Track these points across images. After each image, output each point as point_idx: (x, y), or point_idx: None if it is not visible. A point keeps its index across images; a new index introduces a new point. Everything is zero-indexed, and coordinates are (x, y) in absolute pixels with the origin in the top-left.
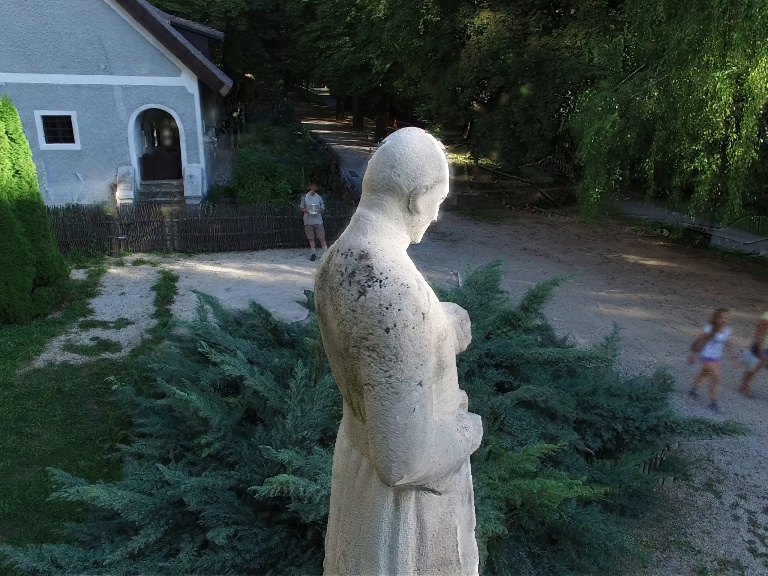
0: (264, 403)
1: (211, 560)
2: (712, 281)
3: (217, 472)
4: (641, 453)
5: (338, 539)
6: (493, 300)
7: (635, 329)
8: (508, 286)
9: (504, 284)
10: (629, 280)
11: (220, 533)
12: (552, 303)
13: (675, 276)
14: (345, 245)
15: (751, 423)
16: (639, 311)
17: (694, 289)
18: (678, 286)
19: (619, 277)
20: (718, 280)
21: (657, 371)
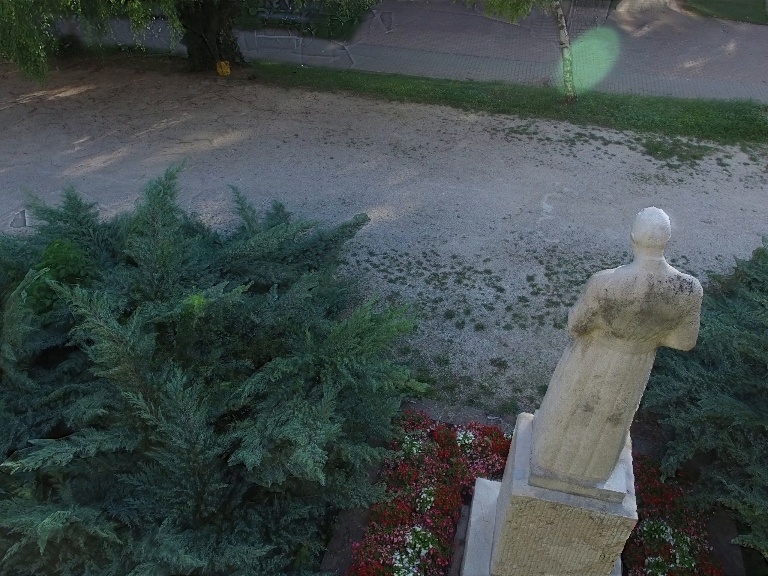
0: (84, 460)
1: (247, 575)
2: (140, 92)
3: (131, 542)
4: (329, 269)
5: (619, 397)
6: (93, 218)
7: (152, 171)
8: (89, 197)
9: (85, 197)
10: (80, 122)
11: (244, 552)
12: (183, 196)
13: (108, 99)
14: (665, 277)
15: (304, 203)
16: (131, 151)
17: (139, 107)
18: (123, 109)
19: (67, 123)
20: (143, 89)
21: (273, 206)
